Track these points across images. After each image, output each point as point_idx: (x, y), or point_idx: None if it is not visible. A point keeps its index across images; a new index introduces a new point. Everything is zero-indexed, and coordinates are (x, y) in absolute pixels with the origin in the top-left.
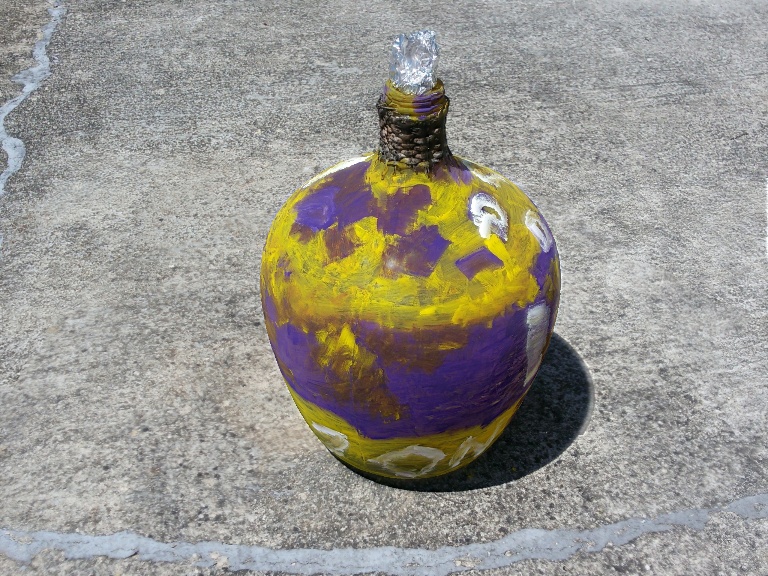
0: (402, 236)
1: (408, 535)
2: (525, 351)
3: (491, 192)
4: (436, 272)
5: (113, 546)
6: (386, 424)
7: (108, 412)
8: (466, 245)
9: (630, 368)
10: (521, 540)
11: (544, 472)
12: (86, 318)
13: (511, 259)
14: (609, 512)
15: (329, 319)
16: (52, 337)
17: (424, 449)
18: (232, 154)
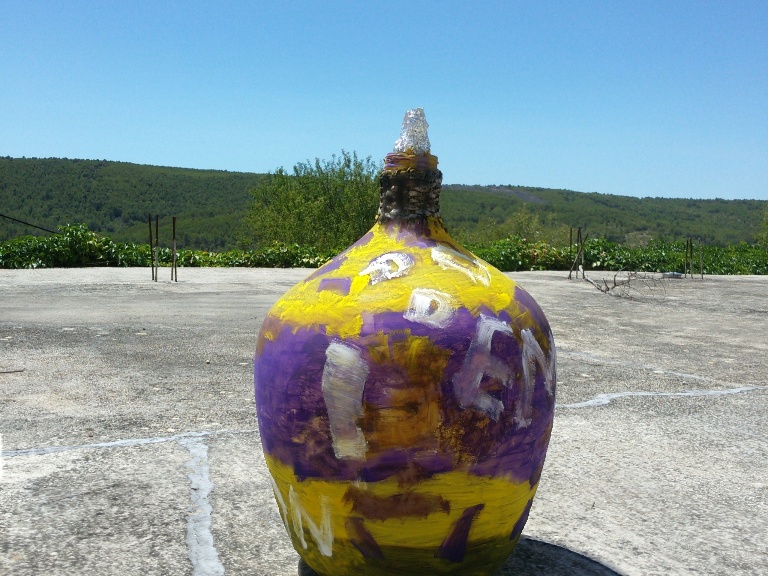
0: None
1: None
2: (321, 389)
3: None
4: None
5: (201, 483)
6: None
7: None
8: (341, 272)
9: None
10: None
11: None
12: None
13: None
14: None
15: None
16: None
17: None
18: None
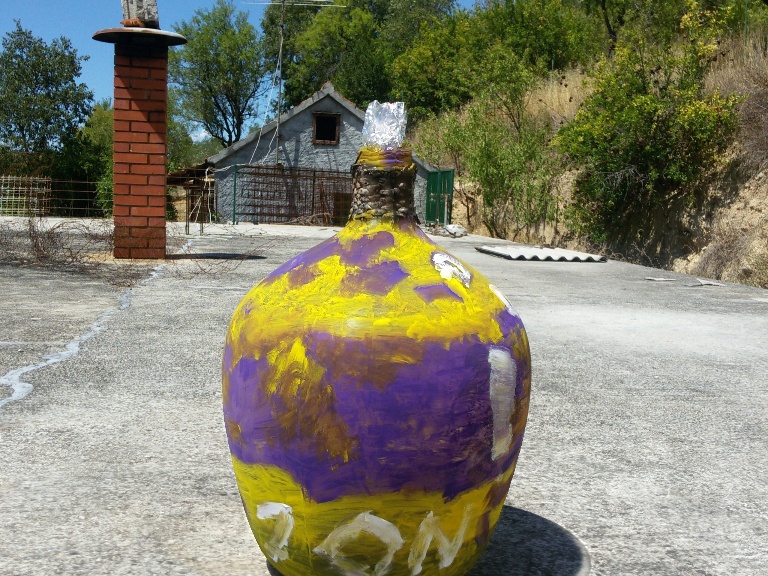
0: (363, 269)
1: None
2: (488, 398)
3: None
4: (393, 293)
5: None
6: (333, 472)
7: (39, 539)
8: (425, 278)
9: (632, 547)
10: None
11: None
12: (46, 481)
13: (472, 301)
14: None
15: (281, 337)
16: (4, 490)
17: (377, 521)
18: None
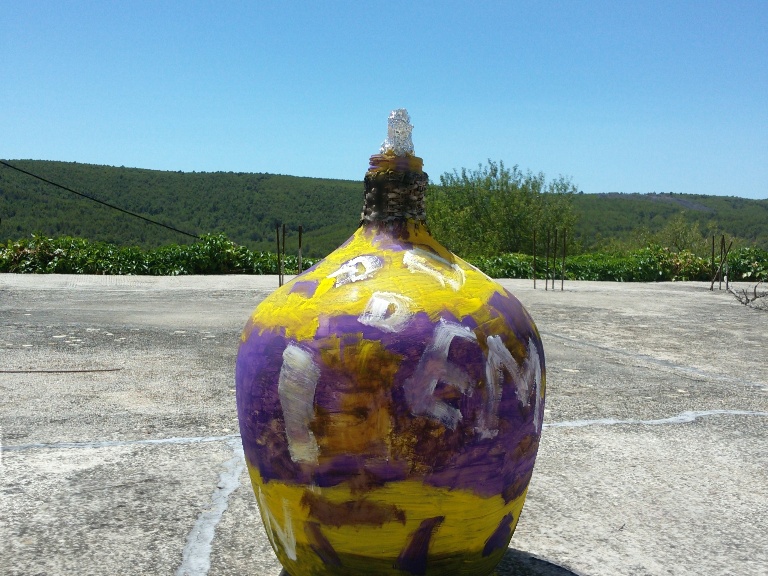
0: None
1: (222, 574)
2: (278, 391)
3: (389, 263)
4: None
5: None
6: None
7: None
8: None
9: None
10: None
11: None
12: None
13: None
14: None
15: None
16: None
17: None
18: None
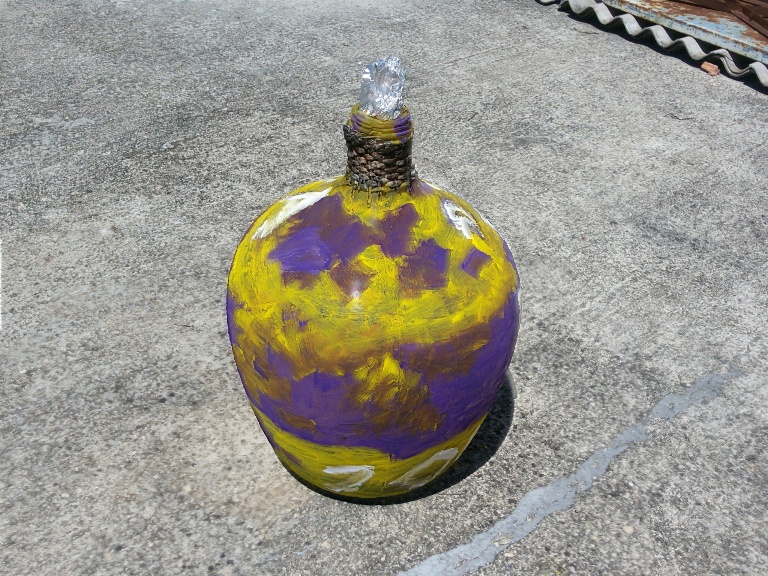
0: (408, 256)
1: (441, 539)
2: None
3: (449, 198)
4: (451, 280)
5: None
6: (423, 439)
7: (62, 547)
8: (462, 249)
9: None
10: (530, 503)
11: (510, 440)
12: None
13: (493, 252)
14: (577, 453)
15: (368, 354)
16: None
17: (446, 452)
18: (8, 235)
